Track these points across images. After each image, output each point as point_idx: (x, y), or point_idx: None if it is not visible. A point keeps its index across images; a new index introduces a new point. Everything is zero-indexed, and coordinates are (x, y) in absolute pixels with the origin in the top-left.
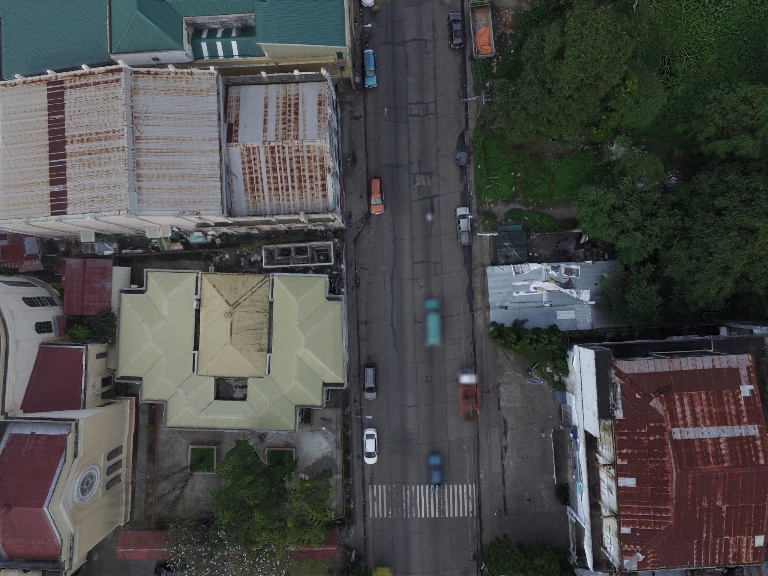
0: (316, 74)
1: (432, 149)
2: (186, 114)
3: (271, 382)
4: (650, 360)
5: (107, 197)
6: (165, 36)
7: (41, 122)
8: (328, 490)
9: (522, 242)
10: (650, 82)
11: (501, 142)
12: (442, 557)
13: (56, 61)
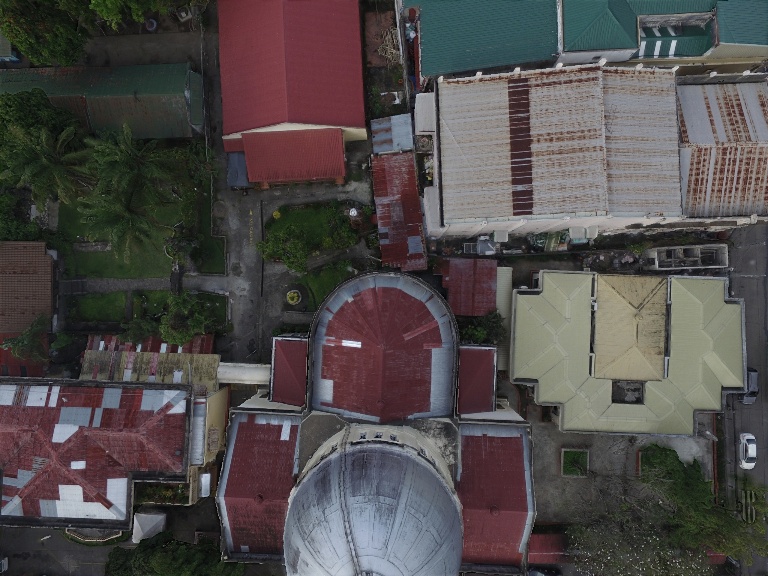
0: (764, 75)
1: None
2: (649, 114)
3: (671, 386)
4: None
5: (582, 197)
6: (624, 35)
7: (501, 120)
8: None
9: None
10: None
11: None
12: None
13: (486, 59)
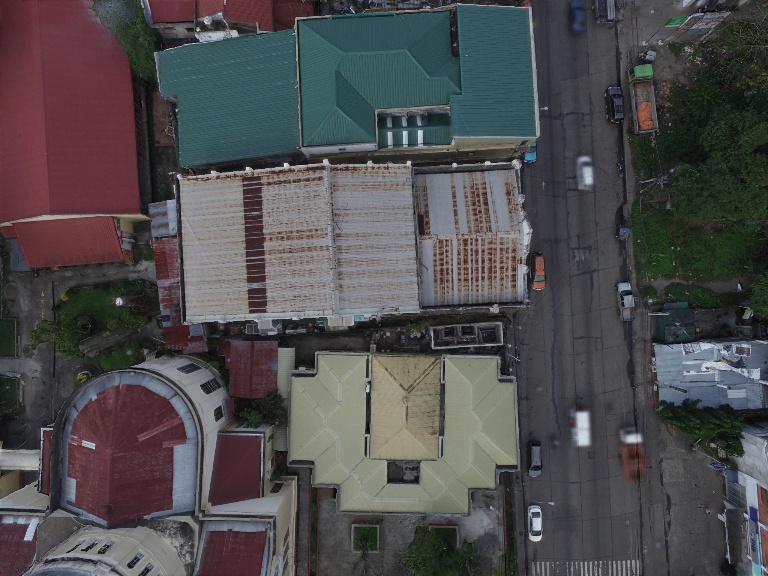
0: (506, 164)
1: (591, 223)
2: (383, 209)
3: (445, 465)
4: None
5: (310, 296)
6: (359, 130)
7: (237, 218)
8: (491, 567)
9: (690, 320)
10: None
11: (661, 216)
12: None
13: (238, 150)
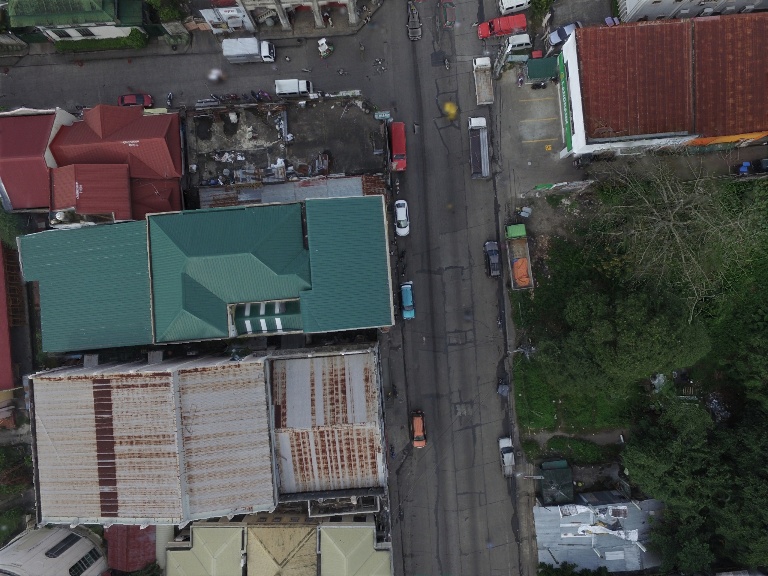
0: (362, 352)
1: (472, 378)
2: (235, 408)
3: None
4: None
5: (159, 503)
6: (210, 327)
7: (88, 420)
8: None
9: (568, 481)
10: (694, 331)
11: (541, 370)
12: None
13: (97, 339)
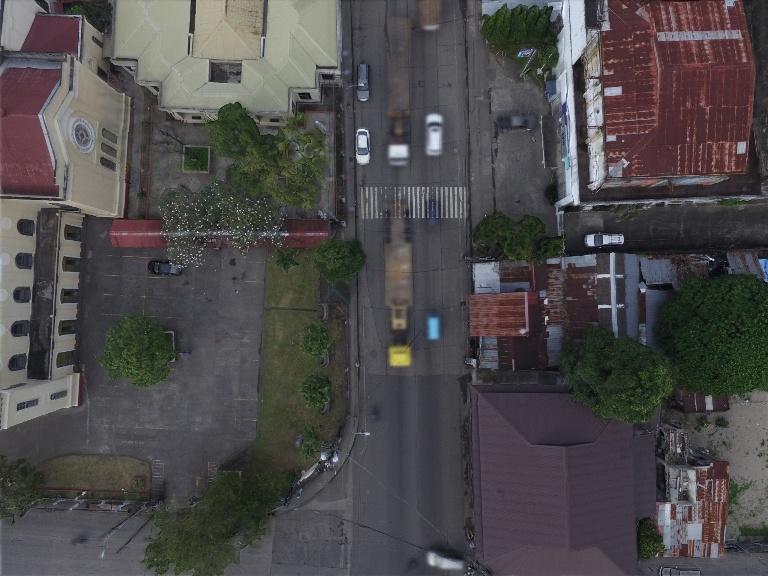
0: None
1: None
2: None
3: (265, 63)
4: None
5: None
6: None
7: None
8: (320, 191)
9: None
10: None
11: None
12: (432, 257)
13: None
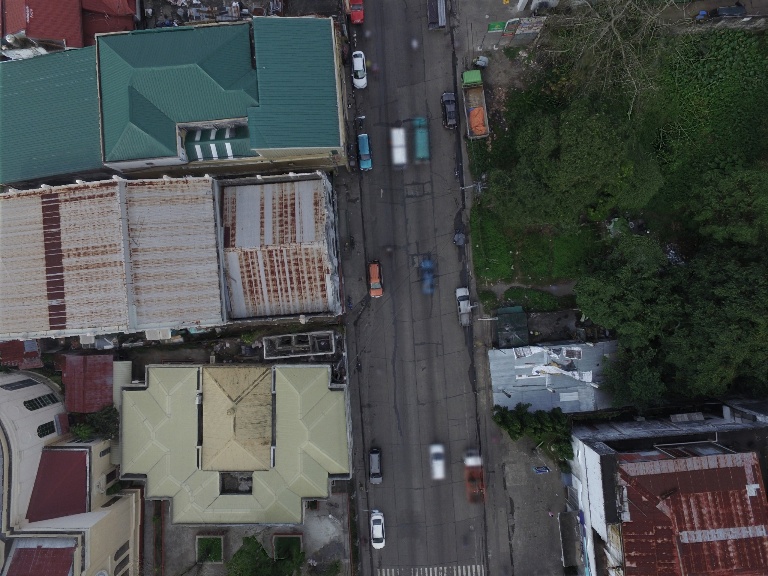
0: (311, 175)
1: (430, 230)
2: (182, 223)
3: (276, 475)
4: (655, 461)
5: (106, 312)
6: (159, 144)
7: (37, 235)
8: (337, 575)
9: (523, 324)
10: (646, 165)
11: (498, 221)
12: None
13: (49, 167)
